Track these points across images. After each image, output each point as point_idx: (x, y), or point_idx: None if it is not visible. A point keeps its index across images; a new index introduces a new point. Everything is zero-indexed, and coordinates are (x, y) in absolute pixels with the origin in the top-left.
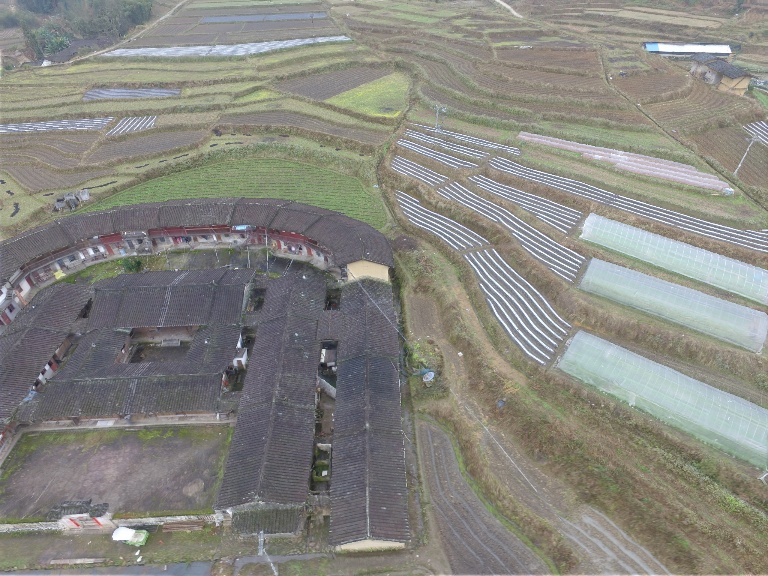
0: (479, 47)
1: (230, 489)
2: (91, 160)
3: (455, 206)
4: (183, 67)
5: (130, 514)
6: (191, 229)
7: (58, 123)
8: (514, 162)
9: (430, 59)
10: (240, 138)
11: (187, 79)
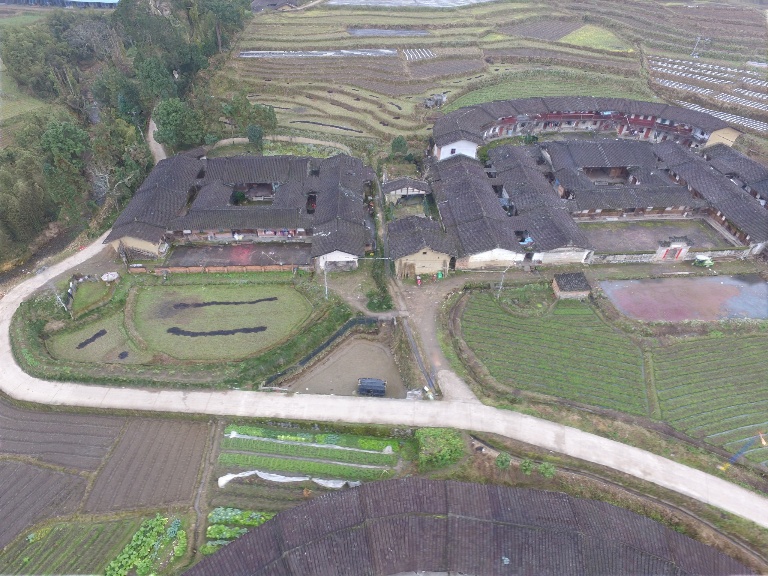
0: (650, 6)
1: (759, 233)
2: (416, 76)
3: (740, 106)
4: (409, 15)
5: (699, 249)
6: (566, 115)
7: (354, 51)
8: (760, 80)
9: (613, 14)
10: (512, 66)
11: (427, 23)
